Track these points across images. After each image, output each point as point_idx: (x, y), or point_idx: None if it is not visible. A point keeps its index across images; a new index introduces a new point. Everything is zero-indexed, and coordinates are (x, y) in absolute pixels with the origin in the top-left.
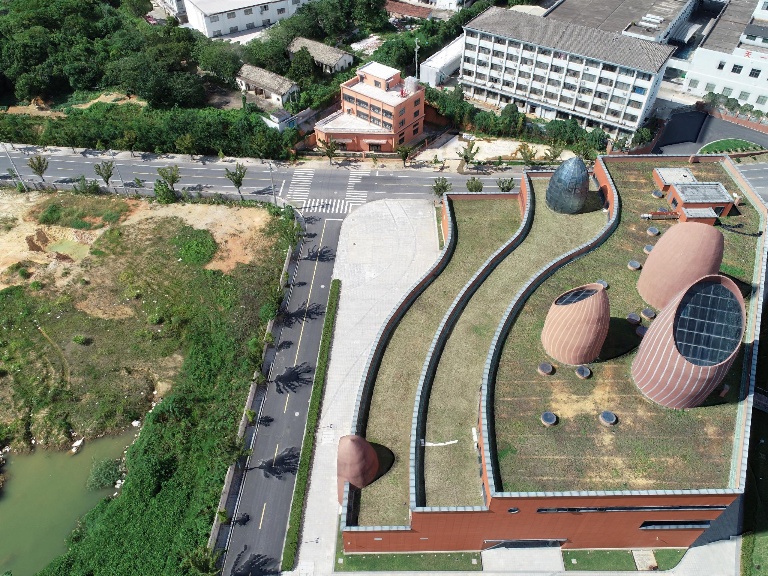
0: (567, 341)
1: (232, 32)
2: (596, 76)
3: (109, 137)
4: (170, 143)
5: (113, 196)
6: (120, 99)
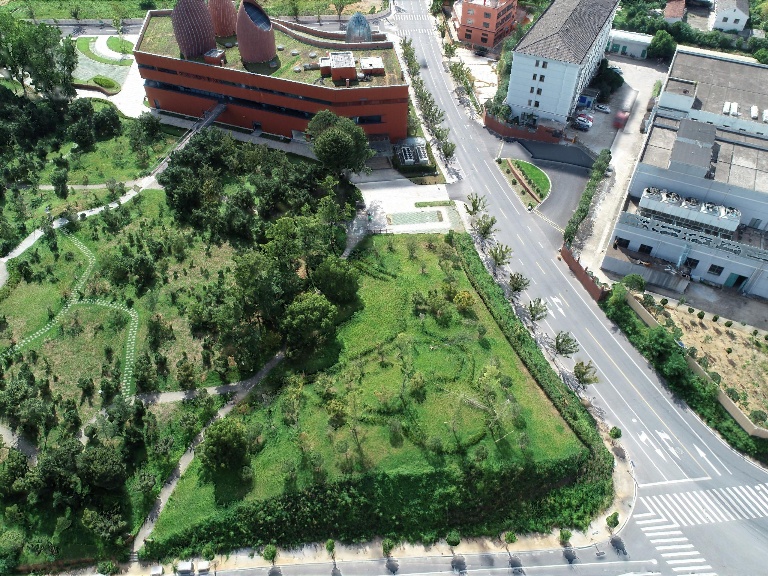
0: None
1: None
2: None
3: None
4: None
5: None
6: None
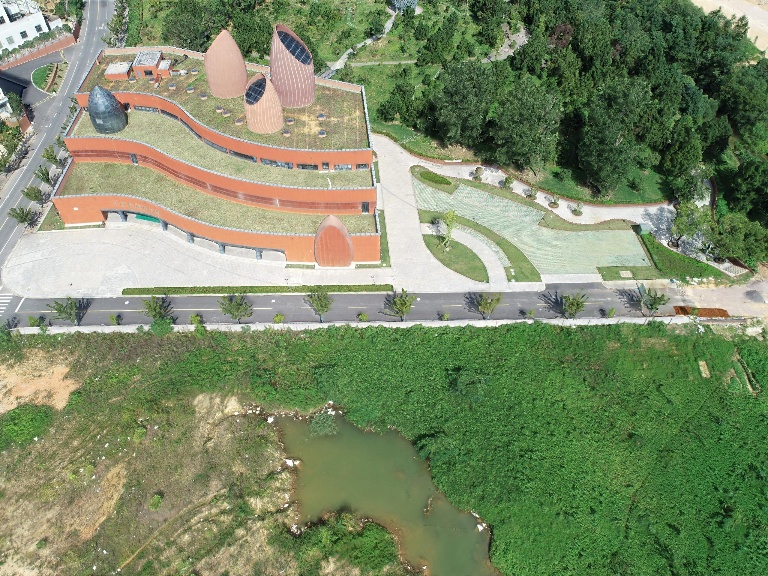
0: (278, 111)
1: None
2: None
3: None
4: None
5: None
6: None
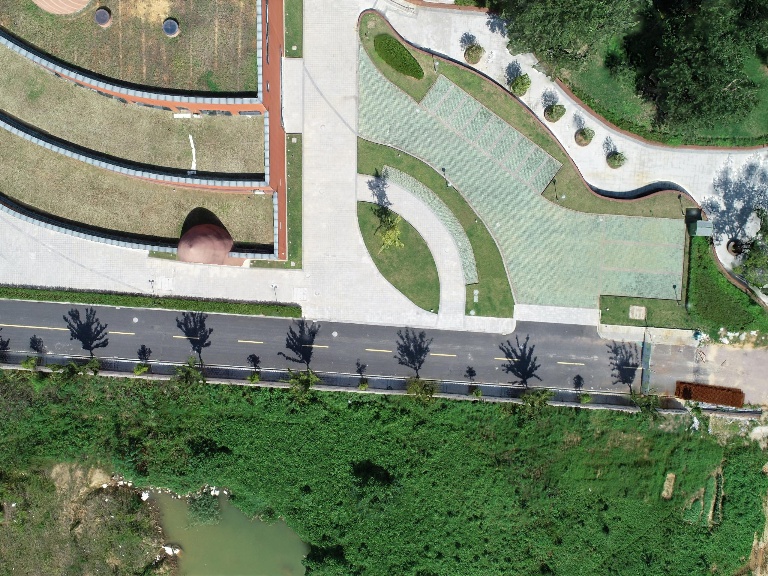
0: None
1: None
2: None
3: None
4: None
5: None
6: None
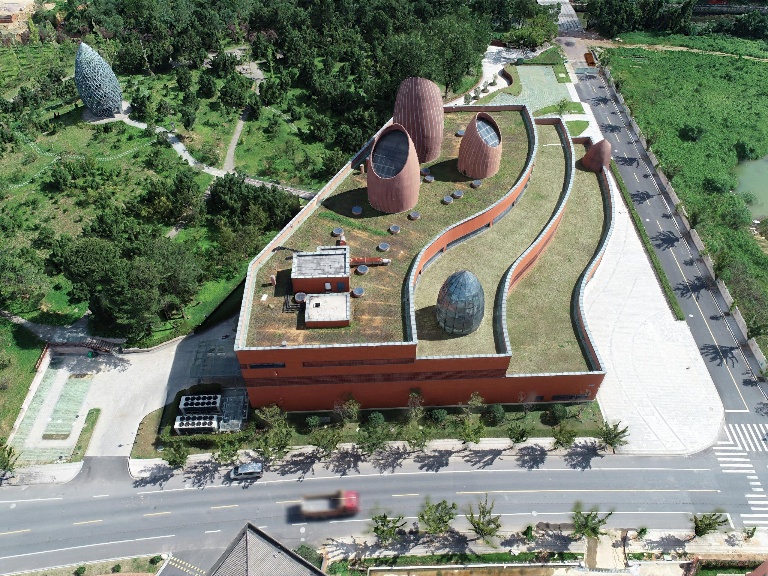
0: None
1: None
2: None
3: None
4: None
5: None
6: None
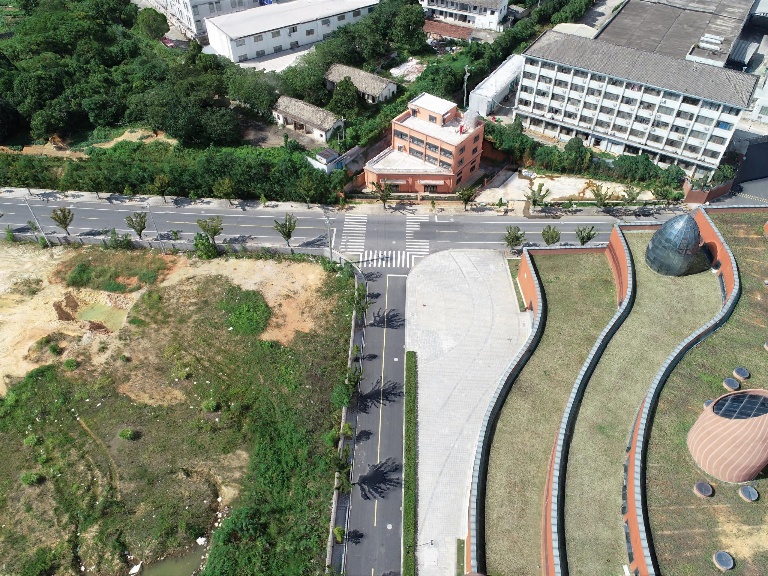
0: (733, 459)
1: (259, 56)
2: (674, 109)
3: (138, 181)
4: (205, 187)
5: (147, 251)
6: (147, 137)
